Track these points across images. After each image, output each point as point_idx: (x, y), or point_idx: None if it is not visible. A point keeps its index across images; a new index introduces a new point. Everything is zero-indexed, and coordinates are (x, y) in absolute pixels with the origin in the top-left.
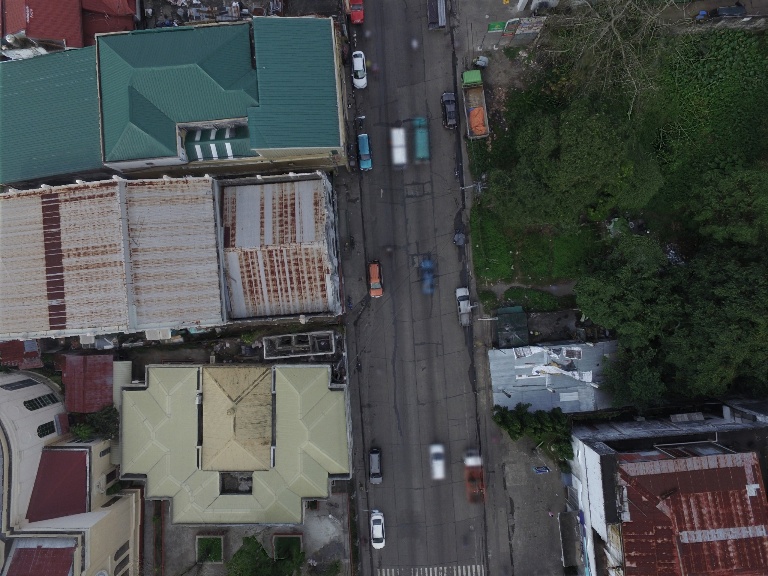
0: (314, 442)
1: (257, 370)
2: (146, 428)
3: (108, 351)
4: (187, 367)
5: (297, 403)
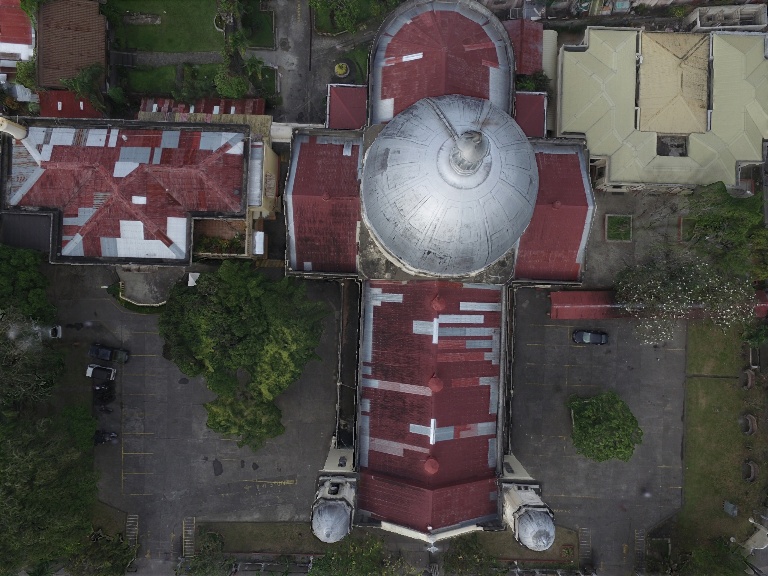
0: (759, 101)
1: (695, 36)
2: (595, 81)
3: (536, 21)
4: (627, 30)
5: (741, 64)
